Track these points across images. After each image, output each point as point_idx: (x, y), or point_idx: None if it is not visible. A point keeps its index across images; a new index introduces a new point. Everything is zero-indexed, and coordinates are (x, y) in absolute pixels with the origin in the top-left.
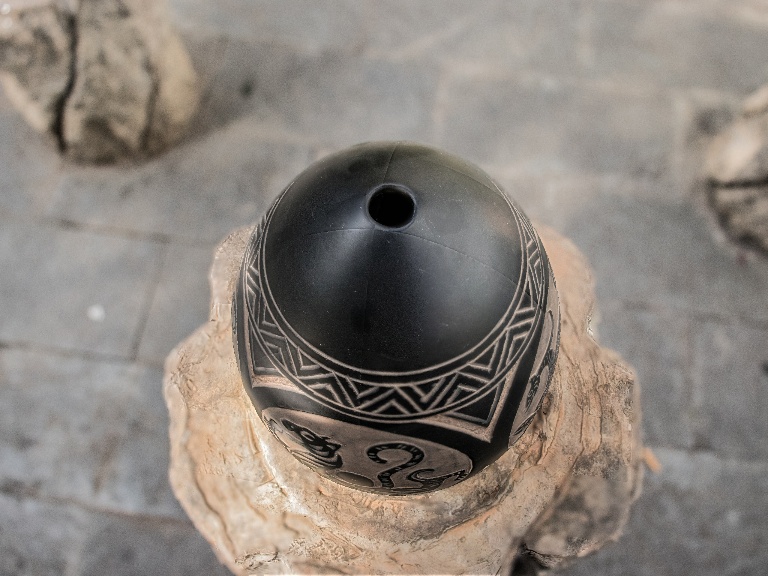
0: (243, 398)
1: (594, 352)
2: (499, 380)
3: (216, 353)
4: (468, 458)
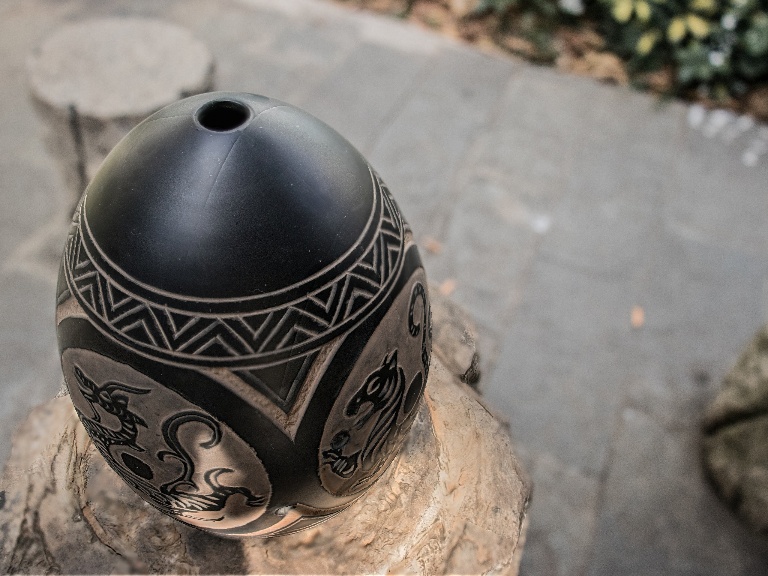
0: None
1: None
2: None
3: None
4: None
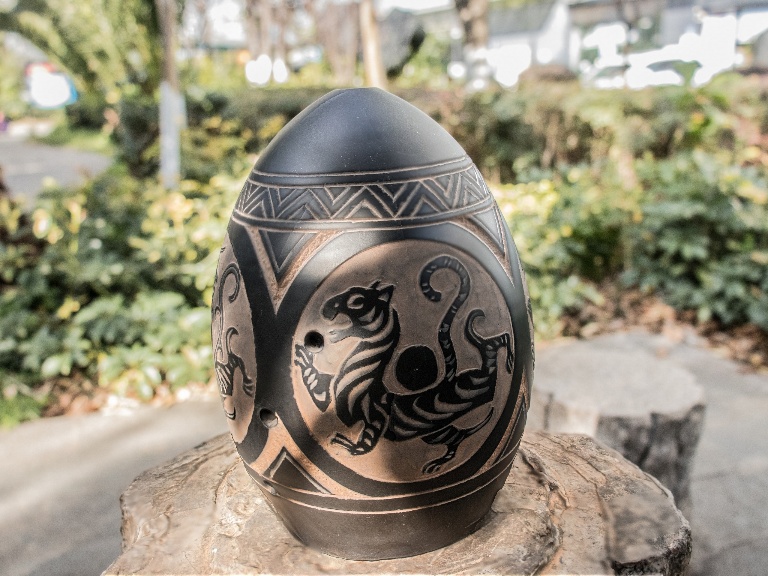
0: (217, 572)
1: (542, 433)
2: (491, 204)
3: (162, 553)
4: (505, 306)
